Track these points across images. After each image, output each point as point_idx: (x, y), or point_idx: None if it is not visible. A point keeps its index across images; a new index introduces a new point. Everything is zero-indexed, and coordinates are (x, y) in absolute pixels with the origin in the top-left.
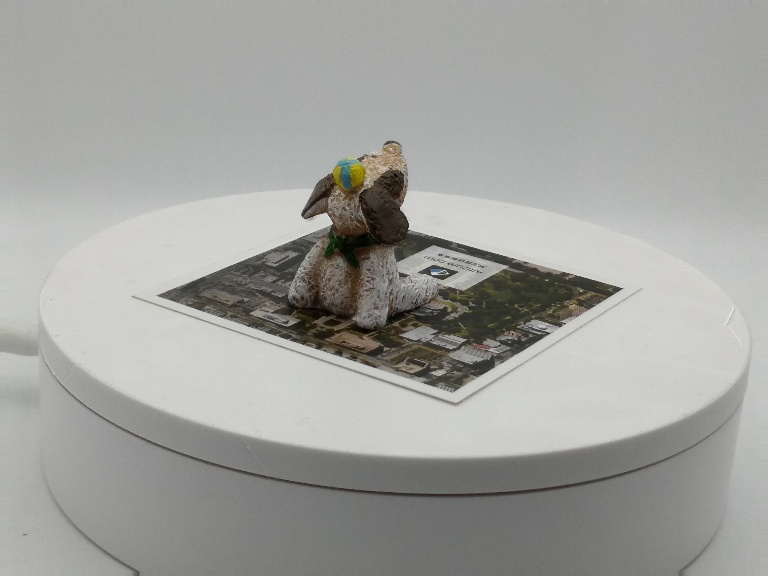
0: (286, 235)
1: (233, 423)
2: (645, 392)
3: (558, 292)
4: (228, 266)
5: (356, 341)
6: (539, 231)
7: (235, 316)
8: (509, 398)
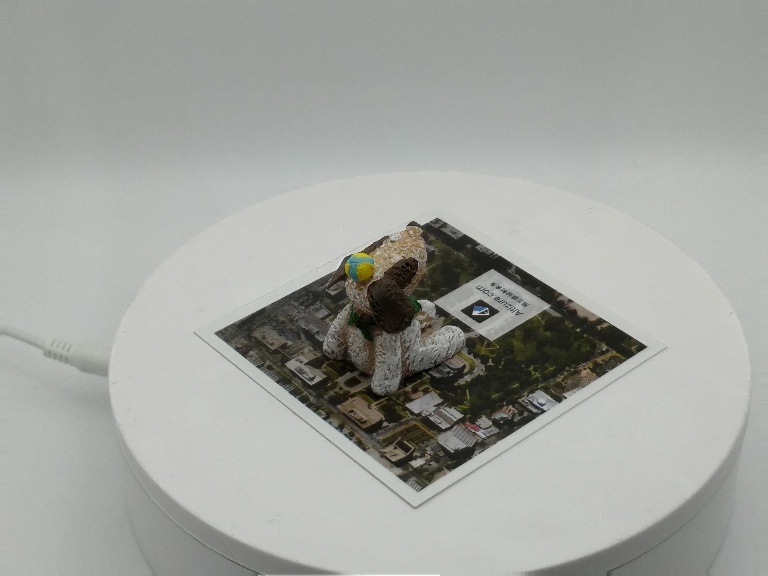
0: (361, 247)
1: (217, 515)
2: (597, 504)
3: (580, 349)
4: (291, 292)
5: (363, 411)
6: (607, 249)
7: (271, 367)
8: (467, 502)
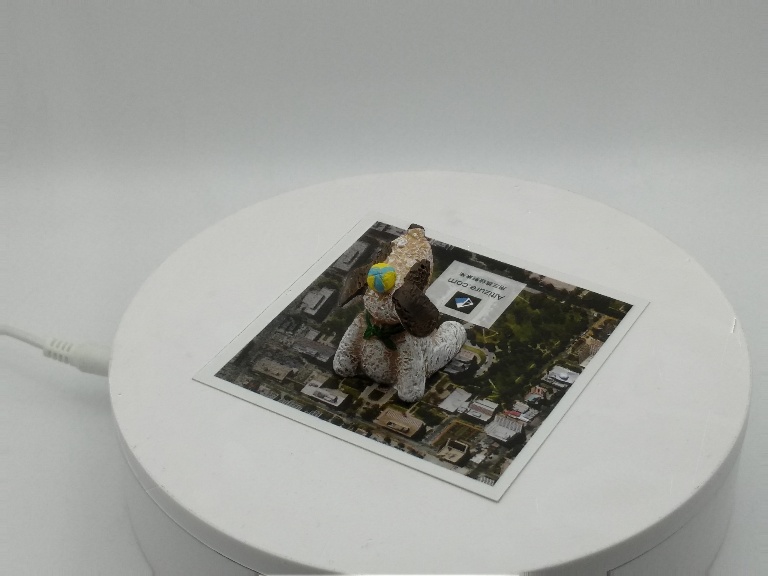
0: (318, 263)
1: (308, 553)
2: (661, 460)
3: (574, 320)
4: (271, 320)
5: (400, 420)
6: (550, 222)
7: (289, 397)
8: (543, 485)
